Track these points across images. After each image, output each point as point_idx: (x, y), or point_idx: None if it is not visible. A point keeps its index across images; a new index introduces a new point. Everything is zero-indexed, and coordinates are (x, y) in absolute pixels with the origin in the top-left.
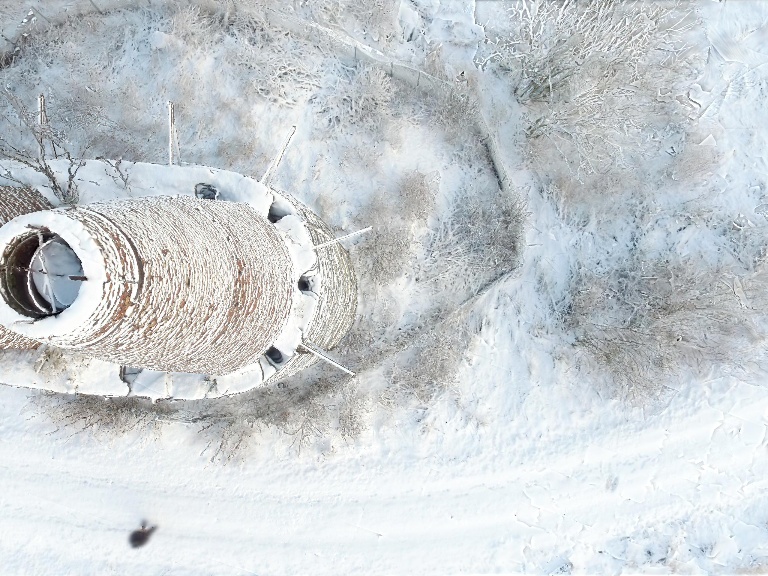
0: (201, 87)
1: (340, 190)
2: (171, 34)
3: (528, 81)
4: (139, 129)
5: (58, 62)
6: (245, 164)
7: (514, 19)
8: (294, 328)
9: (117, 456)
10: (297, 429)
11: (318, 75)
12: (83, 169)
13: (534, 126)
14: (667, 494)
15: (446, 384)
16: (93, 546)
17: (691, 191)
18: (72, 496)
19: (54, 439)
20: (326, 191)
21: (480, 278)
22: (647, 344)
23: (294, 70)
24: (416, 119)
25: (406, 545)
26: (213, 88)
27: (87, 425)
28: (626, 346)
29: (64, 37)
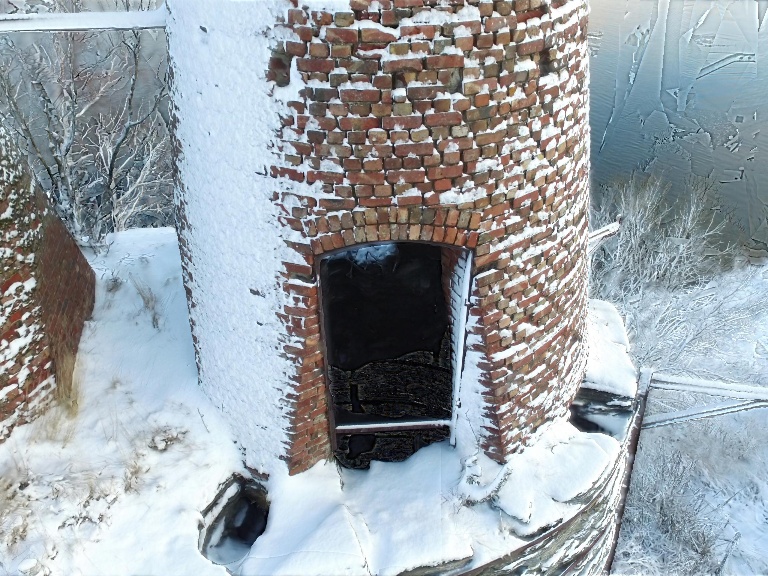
0: None
1: None
2: None
3: None
4: None
5: None
6: None
7: None
8: (604, 342)
9: None
10: None
11: None
12: (115, 234)
13: None
14: None
15: None
16: None
17: None
18: None
19: None
20: None
21: None
22: None
23: None
24: None
25: None
26: None
27: None
28: None
29: None
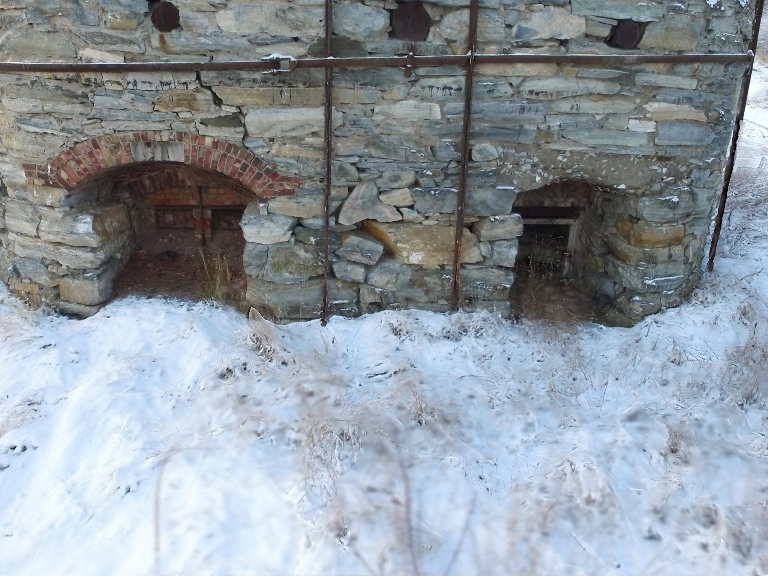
0: None
1: None
2: None
3: None
4: None
5: None
6: (336, 410)
7: None
8: None
9: None
10: None
11: None
12: None
13: None
14: None
15: None
16: None
17: None
18: None
19: None
20: None
21: None
22: None
23: None
24: None
25: None
26: None
27: None
28: None
29: None
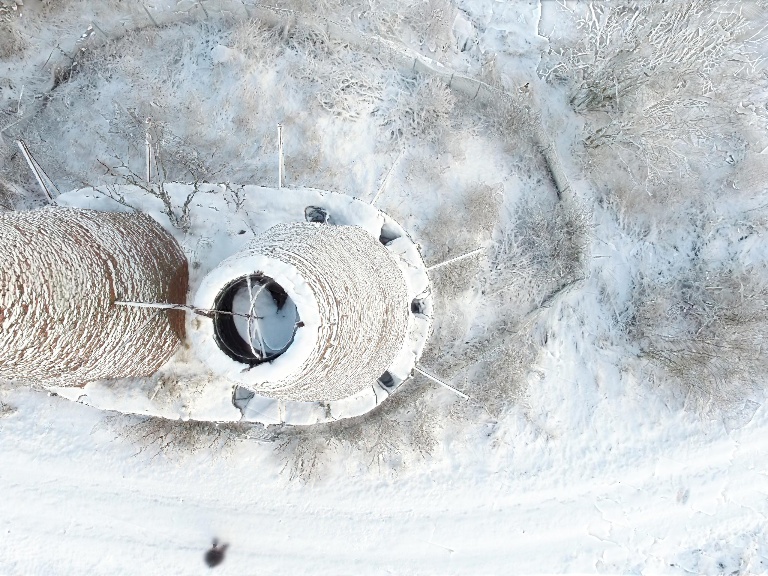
0: (265, 101)
1: (406, 203)
2: (233, 48)
3: (586, 91)
4: (203, 144)
5: (117, 77)
6: (310, 178)
7: (581, 30)
8: (408, 352)
9: (188, 474)
10: (368, 445)
11: (379, 87)
12: None
13: (594, 136)
14: (738, 506)
15: (516, 398)
16: (164, 565)
17: (751, 200)
18: (143, 515)
19: (124, 458)
20: (392, 205)
21: (543, 290)
22: (723, 356)
23: (356, 83)
24: (476, 130)
25: (478, 560)
26: (277, 102)
27: (158, 443)
28: (698, 358)
29: (122, 51)
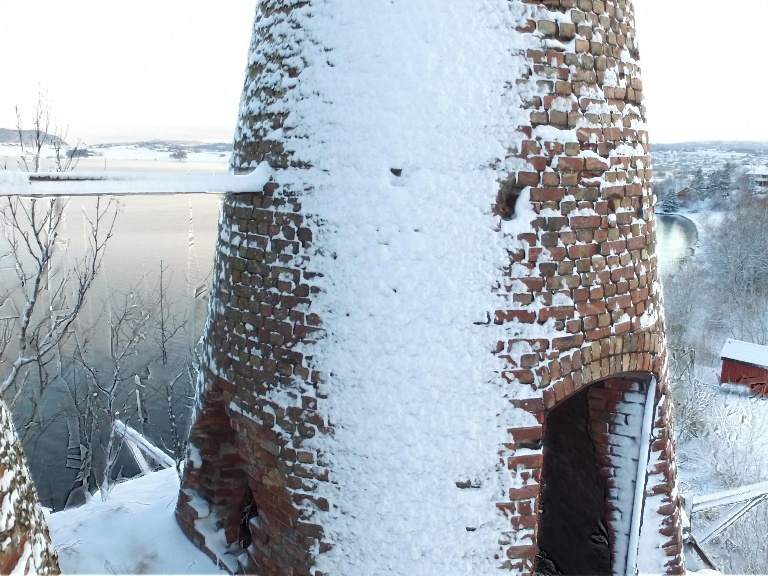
0: None
1: None
2: None
3: None
4: None
5: None
6: None
7: None
8: None
9: None
10: None
11: None
12: None
13: None
14: None
15: None
16: None
17: None
18: None
19: None
20: None
21: None
22: None
23: None
24: None
25: None
26: None
27: None
28: None
29: None
